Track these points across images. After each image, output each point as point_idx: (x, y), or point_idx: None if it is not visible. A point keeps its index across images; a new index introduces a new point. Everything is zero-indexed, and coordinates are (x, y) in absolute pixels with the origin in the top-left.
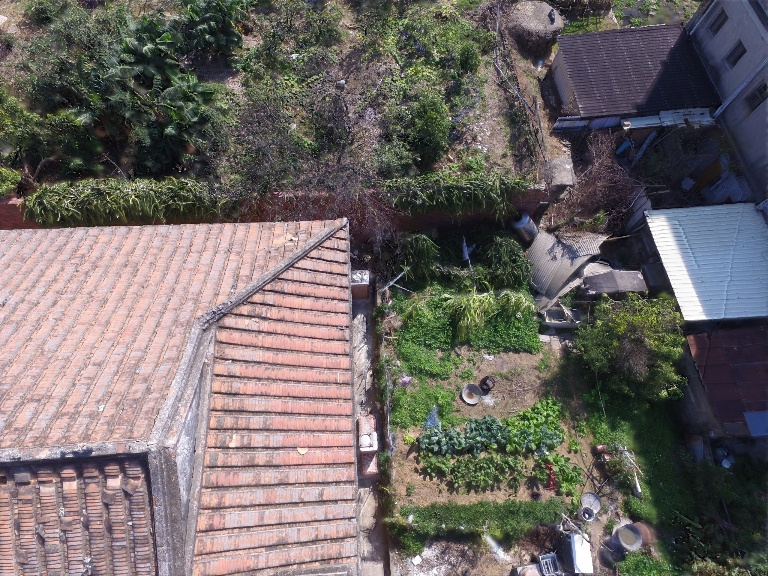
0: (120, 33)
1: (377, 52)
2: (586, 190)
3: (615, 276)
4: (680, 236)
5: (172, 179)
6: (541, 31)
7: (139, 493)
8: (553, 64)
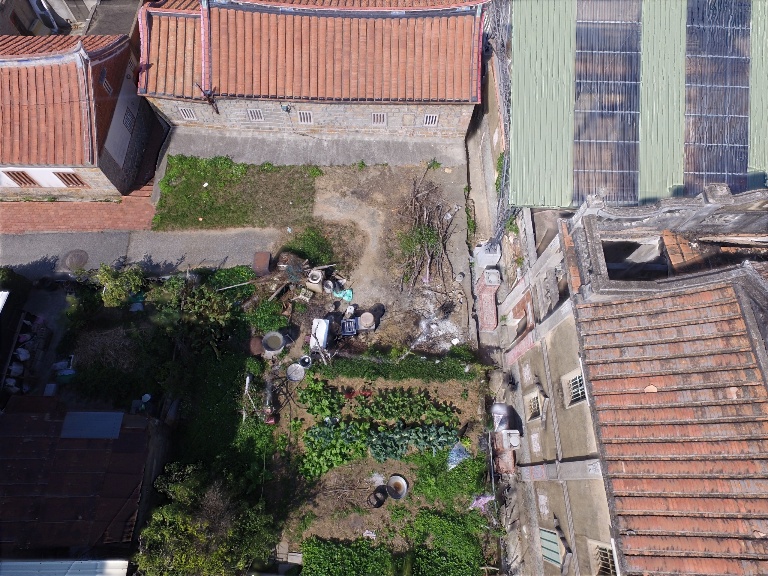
0: None
1: None
2: None
3: None
4: None
5: None
6: None
7: None
8: None
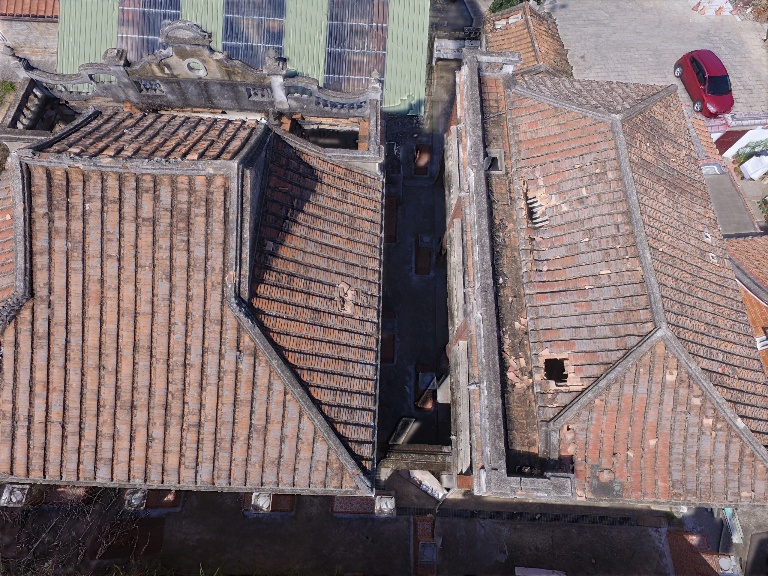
0: None
1: None
2: None
3: None
4: None
5: None
6: None
7: None
8: None
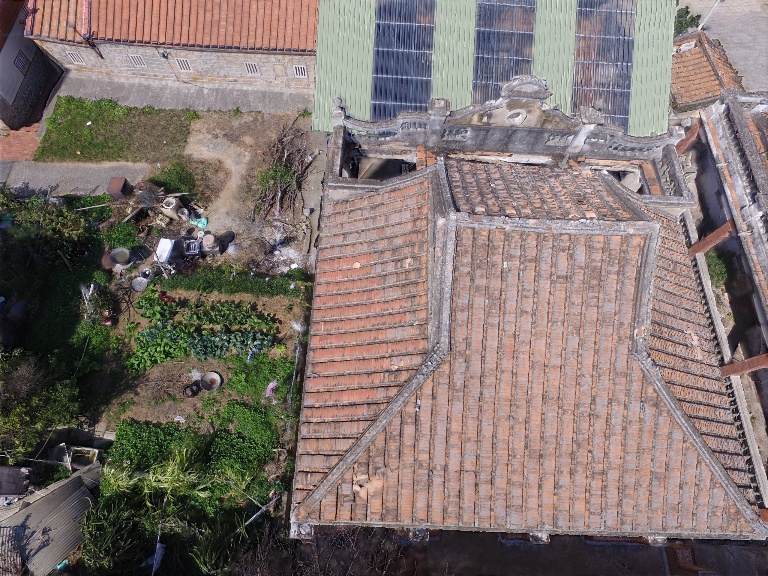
0: None
1: None
2: None
3: None
4: None
5: None
6: None
7: None
8: None
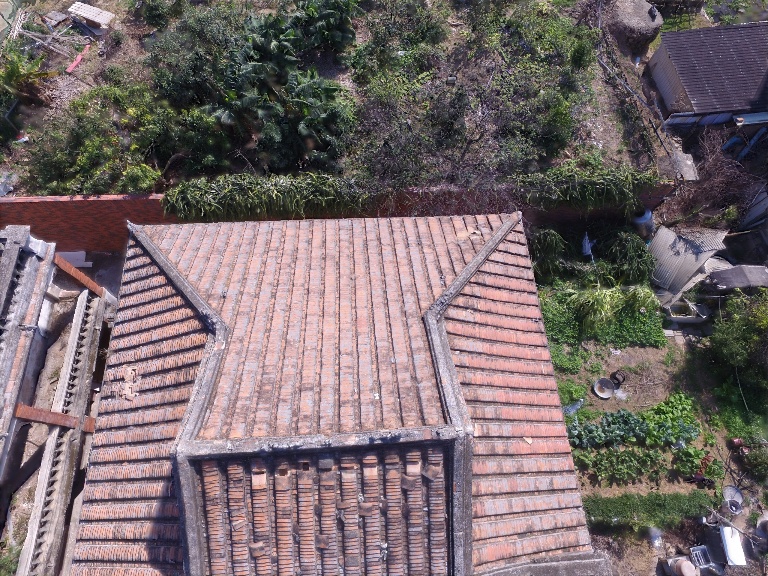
0: (245, 29)
1: (483, 49)
2: (700, 186)
3: (744, 271)
4: None
5: (310, 174)
6: (643, 28)
7: (439, 479)
8: (651, 61)
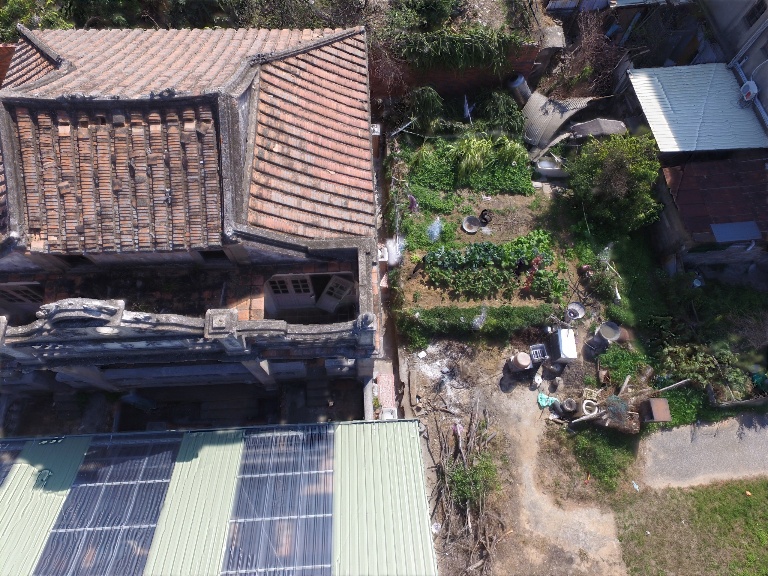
0: None
1: None
2: (576, 62)
3: (600, 122)
4: (659, 89)
5: None
6: None
7: (210, 134)
8: None
